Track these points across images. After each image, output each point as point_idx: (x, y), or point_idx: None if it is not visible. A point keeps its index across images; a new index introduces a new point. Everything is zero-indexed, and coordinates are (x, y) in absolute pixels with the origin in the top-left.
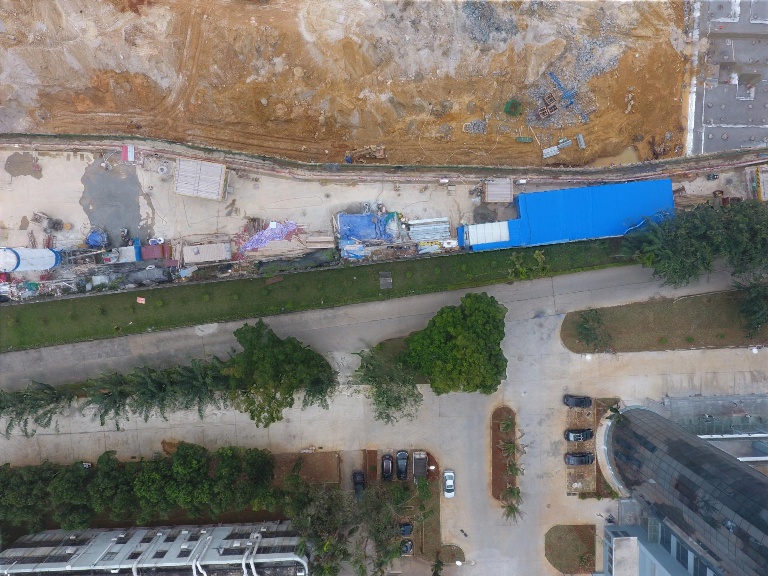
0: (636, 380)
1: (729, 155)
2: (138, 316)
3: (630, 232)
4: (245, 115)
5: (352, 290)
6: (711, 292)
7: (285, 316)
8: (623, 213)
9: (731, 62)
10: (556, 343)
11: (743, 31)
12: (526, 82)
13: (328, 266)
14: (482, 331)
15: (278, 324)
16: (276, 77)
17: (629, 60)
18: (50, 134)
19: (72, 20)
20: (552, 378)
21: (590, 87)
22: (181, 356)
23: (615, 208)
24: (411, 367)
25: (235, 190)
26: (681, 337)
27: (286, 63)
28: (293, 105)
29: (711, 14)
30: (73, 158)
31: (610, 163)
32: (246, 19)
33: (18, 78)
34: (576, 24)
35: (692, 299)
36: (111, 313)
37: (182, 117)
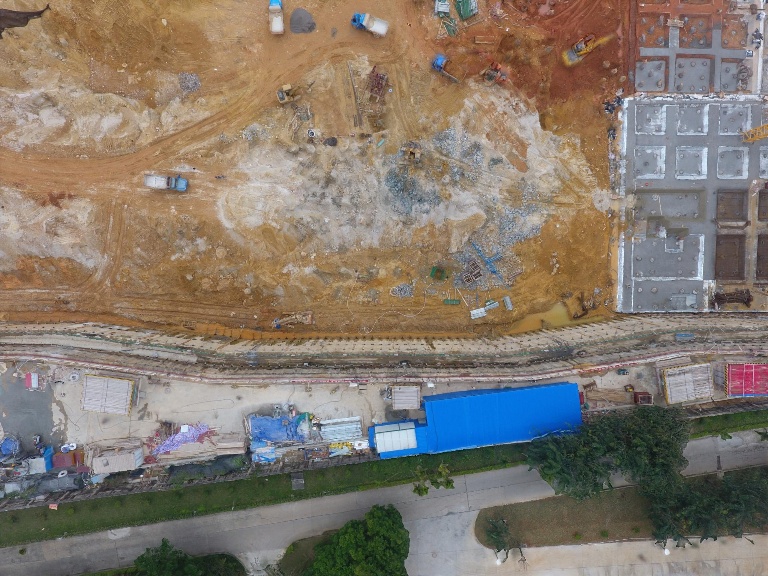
0: (552, 574)
1: (646, 336)
2: (51, 522)
3: (535, 442)
4: (172, 287)
5: (264, 492)
6: (625, 486)
7: (198, 518)
8: (530, 418)
9: (659, 216)
10: (470, 539)
11: (669, 187)
12: (450, 251)
13: (238, 473)
14: (382, 558)
15: (191, 526)
16: (200, 255)
17: (551, 230)
18: None
19: None
20: (467, 574)
21: (515, 251)
22: (94, 560)
23: (522, 414)
24: None
25: (147, 395)
26: (596, 531)
27: (209, 243)
28: (218, 279)
29: (637, 171)
30: None
31: (540, 319)
32: (166, 208)
33: None
34: (498, 194)
35: (606, 493)
36: (24, 520)
37: (109, 292)
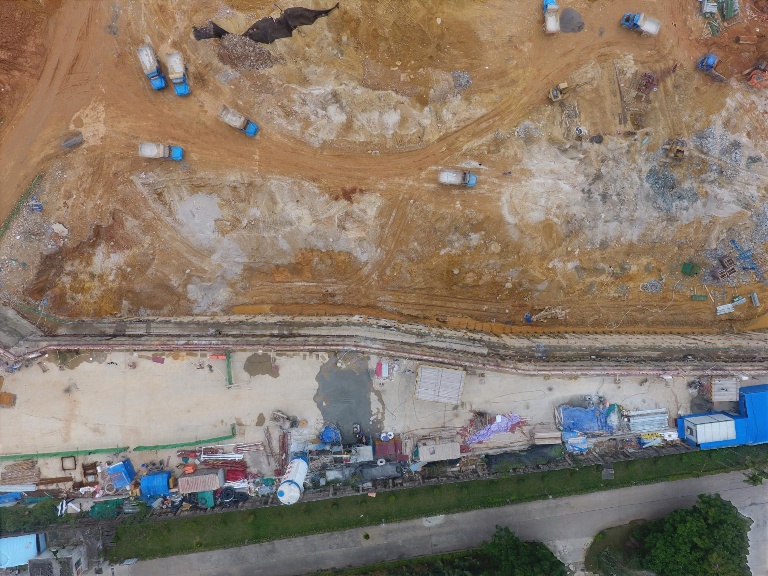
0: None
1: None
2: (369, 509)
3: None
4: (434, 281)
5: (575, 481)
6: None
7: (509, 507)
8: None
9: None
10: None
11: None
12: (707, 247)
13: (557, 462)
14: (732, 545)
15: (503, 514)
16: (470, 250)
17: None
18: (271, 321)
19: (289, 209)
20: (767, 563)
21: (766, 248)
22: (408, 546)
23: None
24: (649, 570)
25: None
26: None
27: (482, 238)
28: (483, 273)
29: None
30: (309, 358)
31: None
32: (451, 203)
33: (228, 257)
34: (756, 192)
35: None
36: (343, 506)
37: (375, 285)
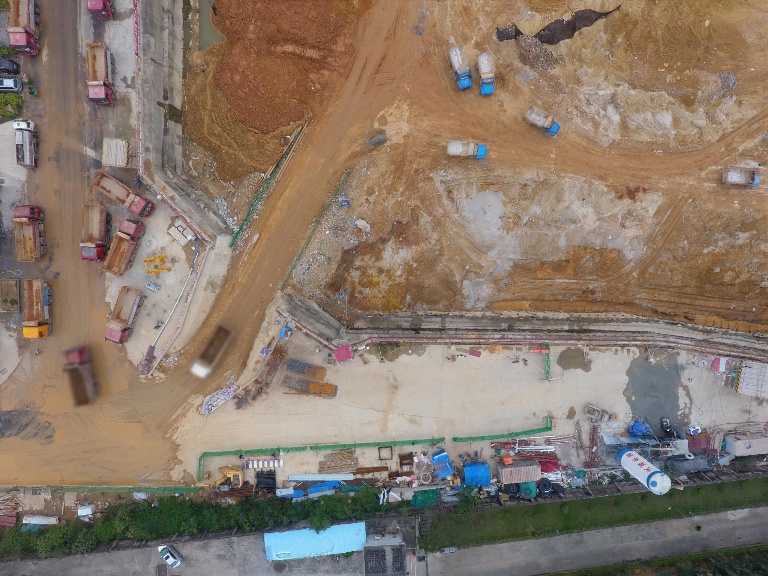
0: None
1: None
2: (676, 502)
3: None
4: (690, 280)
5: None
6: None
7: None
8: None
9: None
10: None
11: None
12: None
13: None
14: None
15: None
16: (734, 249)
17: None
18: (562, 317)
19: (575, 207)
20: None
21: None
22: (713, 539)
23: None
24: None
25: None
26: None
27: (749, 237)
28: (742, 272)
29: None
30: (620, 353)
31: None
32: (730, 203)
33: (503, 254)
34: None
35: None
36: (652, 499)
37: (634, 283)
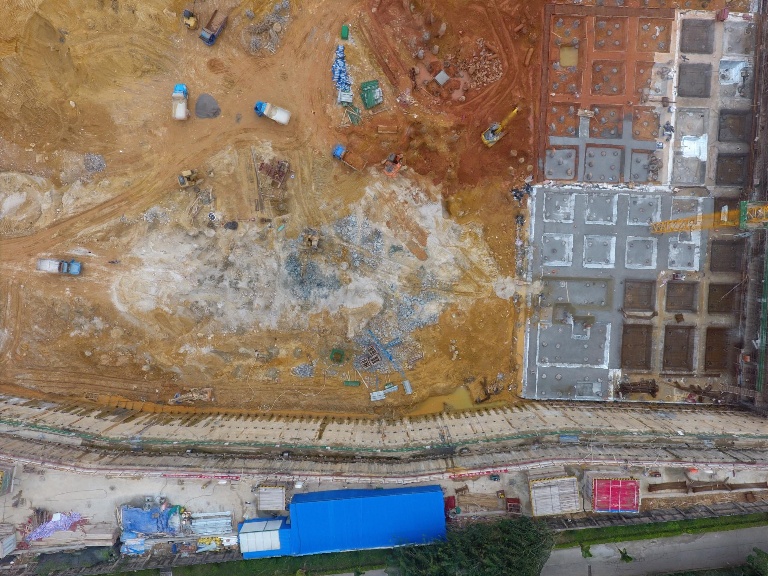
0: None
1: None
2: None
3: (394, 551)
4: (73, 361)
5: None
6: None
7: None
8: (394, 525)
9: (566, 303)
10: None
11: (576, 275)
12: (347, 336)
13: (104, 565)
14: None
15: None
16: (98, 333)
17: (447, 319)
18: None
19: None
20: None
21: (415, 337)
22: None
23: (386, 520)
24: None
25: (22, 482)
26: None
27: (106, 323)
28: (117, 356)
29: (545, 257)
30: None
31: (442, 401)
32: (61, 290)
33: None
34: (397, 281)
35: None
36: None
37: (10, 364)
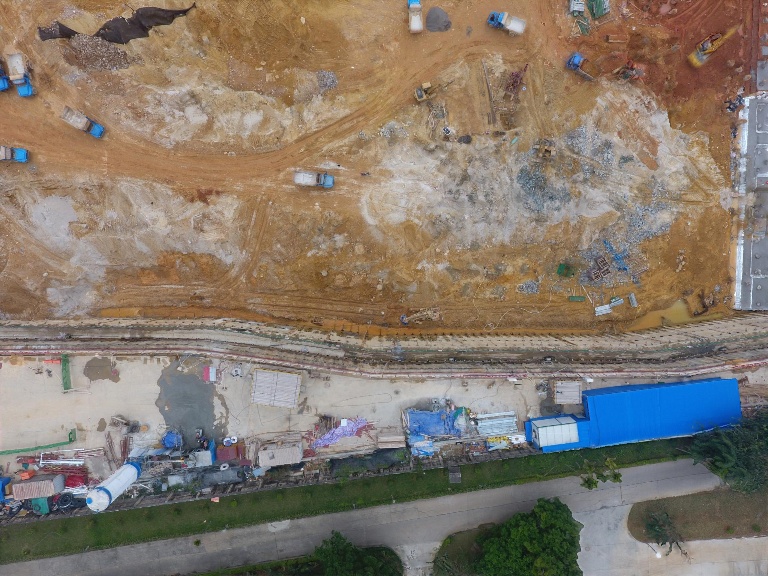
0: (703, 568)
1: None
2: (212, 514)
3: (699, 437)
4: (305, 283)
5: (422, 485)
6: None
7: (356, 511)
8: (690, 413)
9: None
10: (623, 533)
11: None
12: (580, 248)
13: (400, 467)
14: (559, 550)
15: (349, 519)
16: (337, 251)
17: (681, 227)
18: (122, 325)
19: (143, 211)
20: (619, 567)
21: (642, 249)
22: (254, 552)
23: (682, 409)
24: None
25: (307, 389)
26: (747, 525)
27: (347, 240)
28: (352, 275)
29: (757, 169)
30: (150, 362)
31: (660, 316)
32: (310, 205)
33: (88, 260)
34: (628, 192)
35: None
36: (186, 512)
37: (244, 288)
